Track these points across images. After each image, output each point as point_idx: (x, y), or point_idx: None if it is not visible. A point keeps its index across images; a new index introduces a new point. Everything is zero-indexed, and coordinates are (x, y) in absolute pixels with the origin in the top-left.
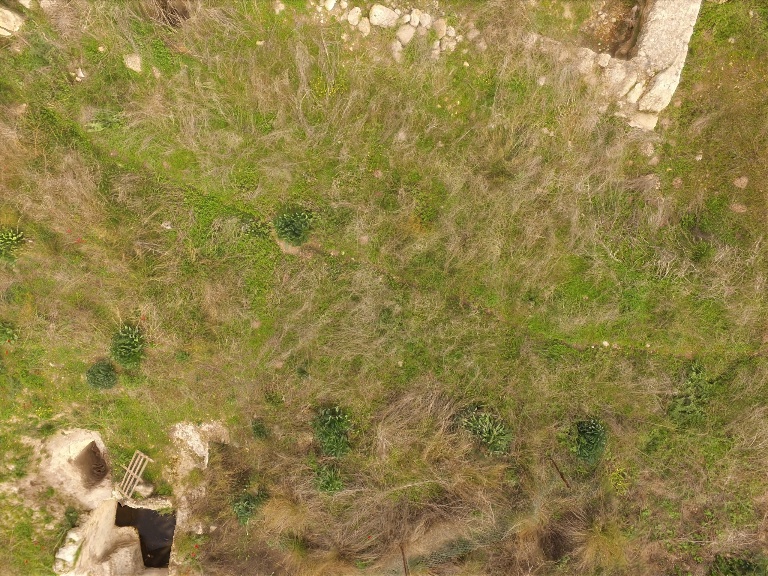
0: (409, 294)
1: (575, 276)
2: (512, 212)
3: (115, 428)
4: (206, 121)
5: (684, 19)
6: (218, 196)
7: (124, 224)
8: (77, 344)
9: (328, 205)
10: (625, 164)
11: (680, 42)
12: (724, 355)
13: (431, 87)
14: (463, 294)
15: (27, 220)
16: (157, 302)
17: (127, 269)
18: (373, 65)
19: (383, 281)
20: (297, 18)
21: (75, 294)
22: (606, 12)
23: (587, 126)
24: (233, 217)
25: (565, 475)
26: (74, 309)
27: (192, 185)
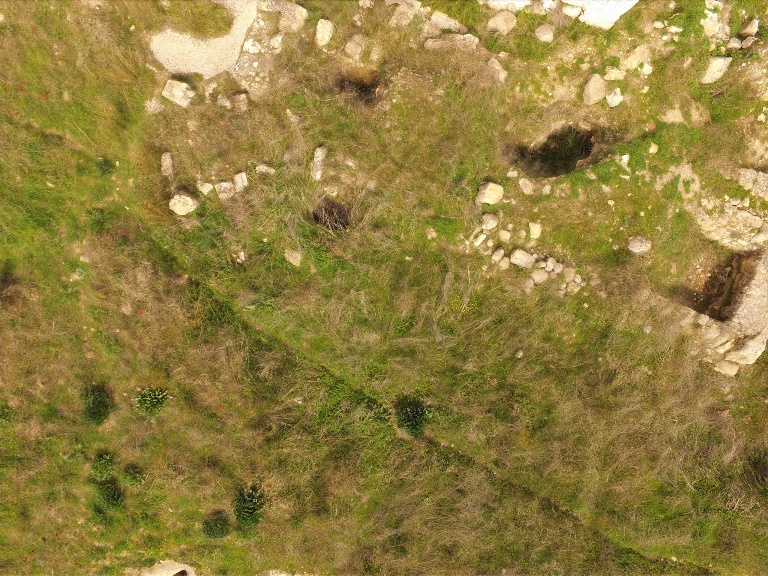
0: (507, 490)
1: (655, 497)
2: (609, 437)
3: (213, 568)
4: (351, 318)
5: None
6: (348, 380)
7: (263, 398)
8: (198, 495)
9: (448, 405)
10: None
11: None
12: None
13: (556, 326)
14: (555, 497)
15: (173, 379)
16: (280, 469)
17: (262, 442)
18: (505, 293)
19: (485, 476)
20: (446, 245)
21: (204, 450)
22: (703, 266)
23: (683, 374)
24: (360, 402)
25: None
26: (202, 464)
27: (325, 366)
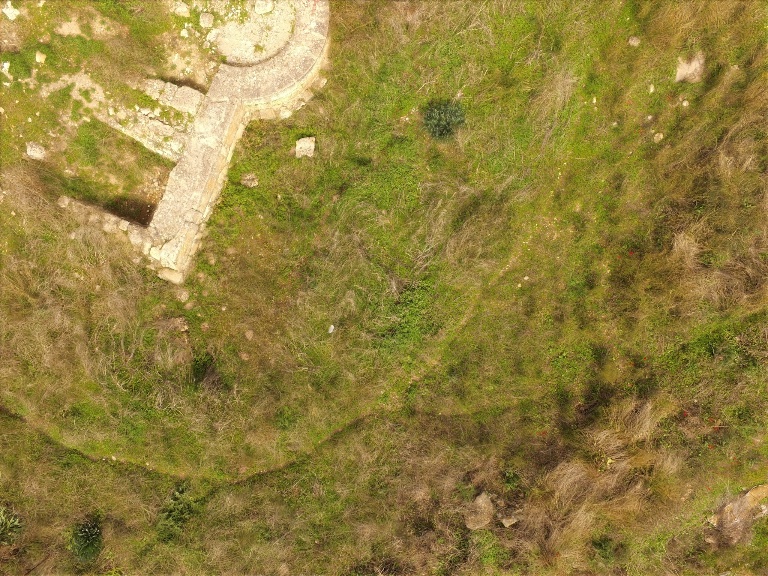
0: None
1: (90, 398)
2: None
3: None
4: None
5: (187, 203)
6: None
7: None
8: None
9: None
10: (157, 307)
11: (182, 220)
12: (210, 479)
13: None
14: (1, 401)
15: None
16: None
17: None
18: None
19: None
20: None
21: None
22: (161, 180)
23: (102, 278)
24: None
25: (55, 570)
26: None
27: None
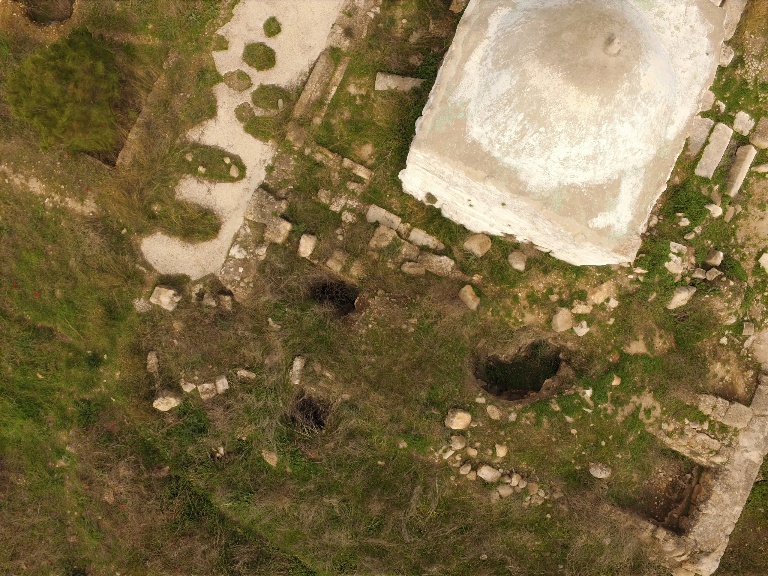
0: None
1: None
2: None
3: None
4: (323, 518)
5: (729, 517)
6: (319, 573)
7: None
8: None
9: None
10: None
11: (723, 535)
12: None
13: None
14: None
15: (151, 568)
16: None
17: None
18: (472, 501)
19: None
20: (416, 454)
21: None
22: (665, 470)
23: None
24: None
25: None
26: None
27: (298, 557)
